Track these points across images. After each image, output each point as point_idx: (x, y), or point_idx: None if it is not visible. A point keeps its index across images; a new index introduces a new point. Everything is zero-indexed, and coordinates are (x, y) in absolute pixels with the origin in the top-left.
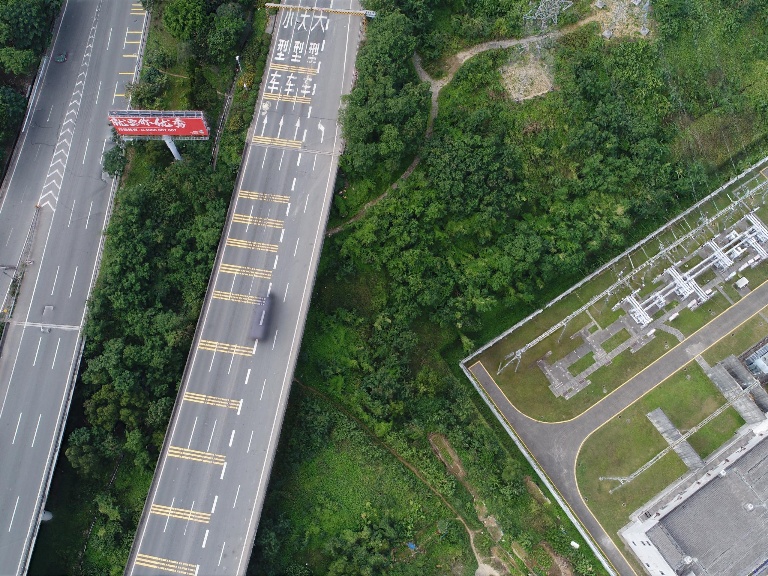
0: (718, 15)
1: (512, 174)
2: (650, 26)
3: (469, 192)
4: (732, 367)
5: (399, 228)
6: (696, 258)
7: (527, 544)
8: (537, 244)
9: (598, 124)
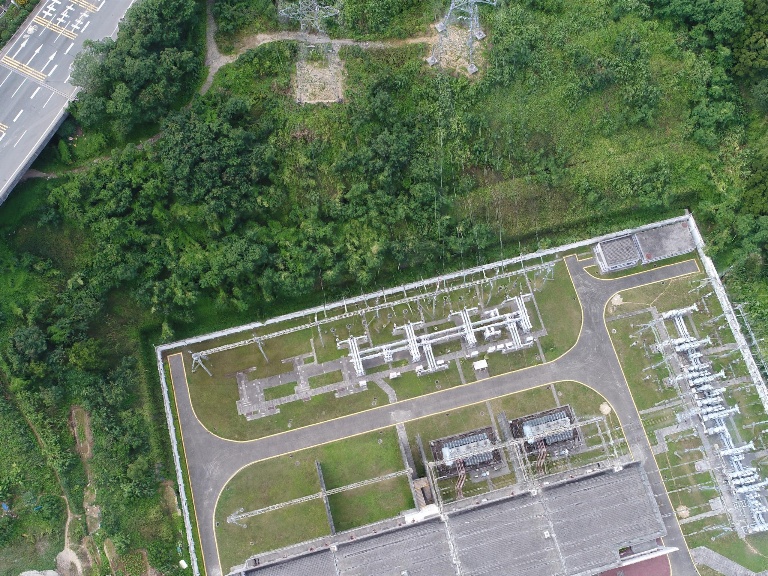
0: (567, 76)
1: (255, 175)
2: (482, 66)
3: (197, 179)
4: None
5: (107, 192)
6: (450, 324)
7: (121, 546)
8: (255, 254)
9: (377, 152)
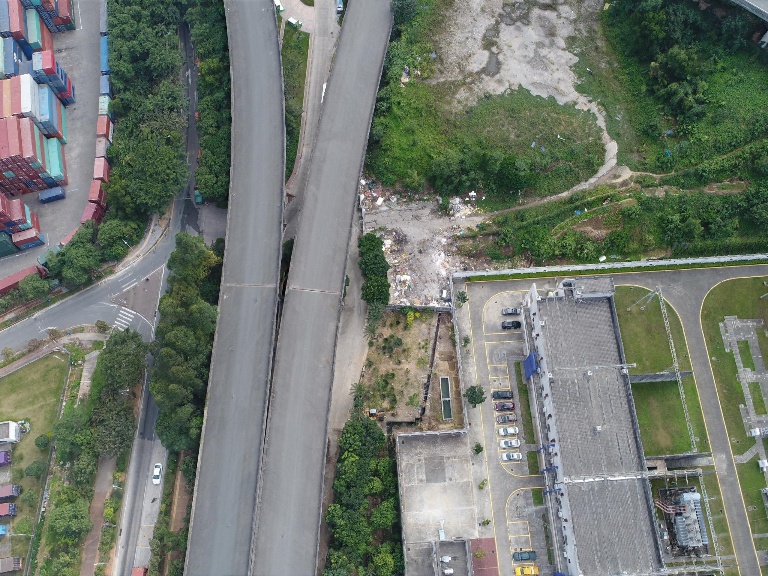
0: None
1: None
2: None
3: None
4: None
5: None
6: None
7: None
8: None
9: None
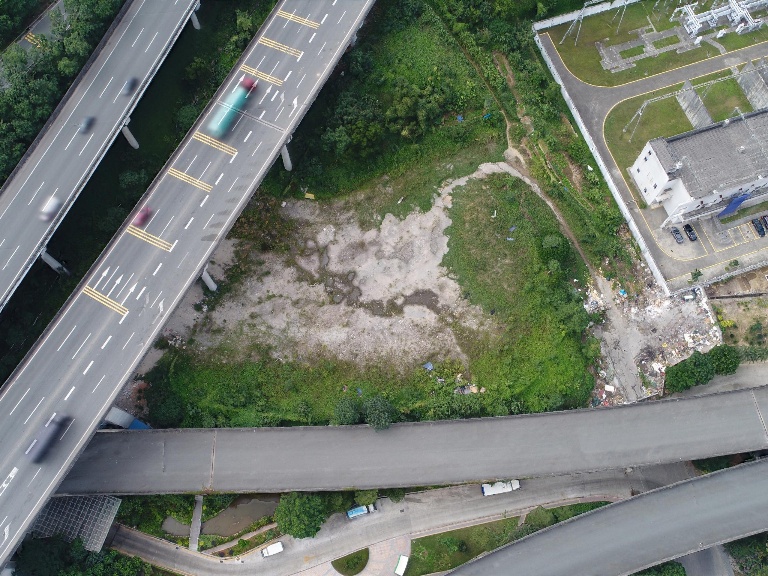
0: None
1: None
2: None
3: None
4: (760, 71)
5: None
6: None
7: (551, 144)
8: None
9: None
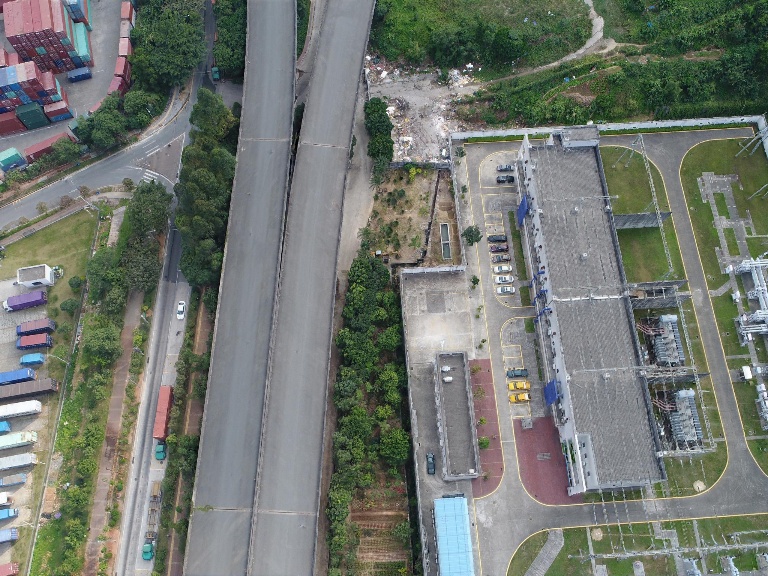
0: None
1: None
2: None
3: None
4: None
5: None
6: None
7: None
8: None
9: None
